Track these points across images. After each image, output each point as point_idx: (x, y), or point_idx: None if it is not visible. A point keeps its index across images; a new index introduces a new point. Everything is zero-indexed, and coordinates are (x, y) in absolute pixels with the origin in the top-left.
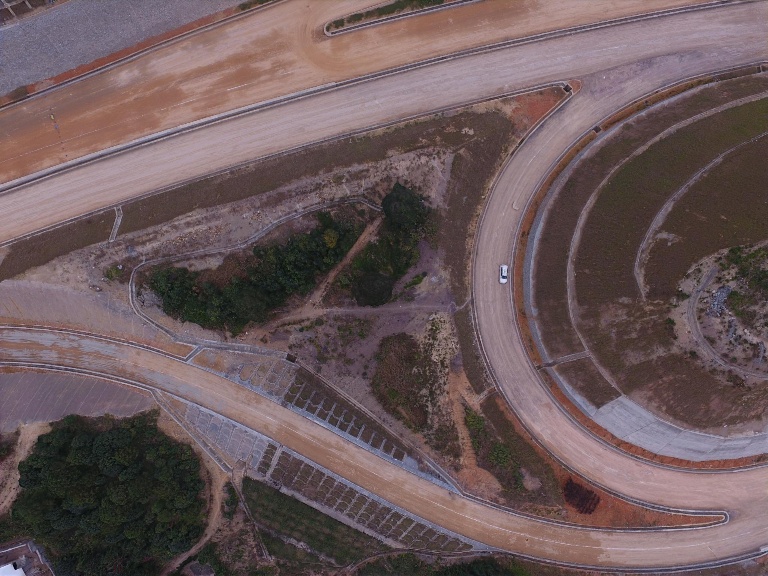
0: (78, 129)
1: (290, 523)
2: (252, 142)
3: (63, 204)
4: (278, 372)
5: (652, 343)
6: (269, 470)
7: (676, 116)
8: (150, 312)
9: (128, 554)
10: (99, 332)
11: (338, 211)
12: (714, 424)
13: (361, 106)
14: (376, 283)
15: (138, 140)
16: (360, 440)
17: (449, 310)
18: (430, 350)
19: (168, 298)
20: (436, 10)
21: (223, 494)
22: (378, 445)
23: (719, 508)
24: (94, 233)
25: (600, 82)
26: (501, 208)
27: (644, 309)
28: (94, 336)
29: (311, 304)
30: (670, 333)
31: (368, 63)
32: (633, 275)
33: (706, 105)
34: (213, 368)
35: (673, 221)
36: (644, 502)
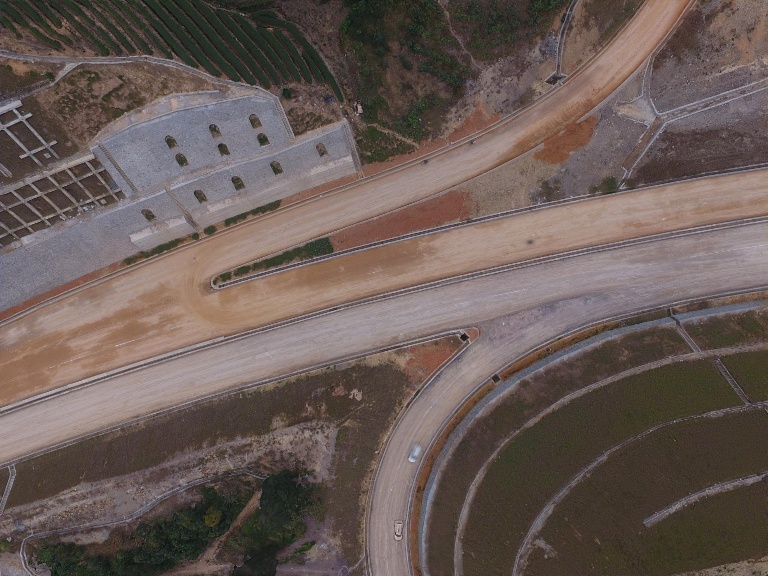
0: None
1: None
2: (142, 397)
3: None
4: None
5: None
6: None
7: (571, 382)
8: (44, 574)
9: None
10: None
11: (222, 485)
12: None
13: (252, 359)
14: None
15: (28, 400)
16: None
17: (340, 575)
18: None
19: (55, 575)
20: (326, 259)
21: None
22: None
23: None
24: None
25: (499, 329)
26: (396, 461)
27: None
28: None
29: (205, 561)
30: None
31: (258, 315)
32: None
33: (603, 371)
34: None
35: (551, 529)
36: None
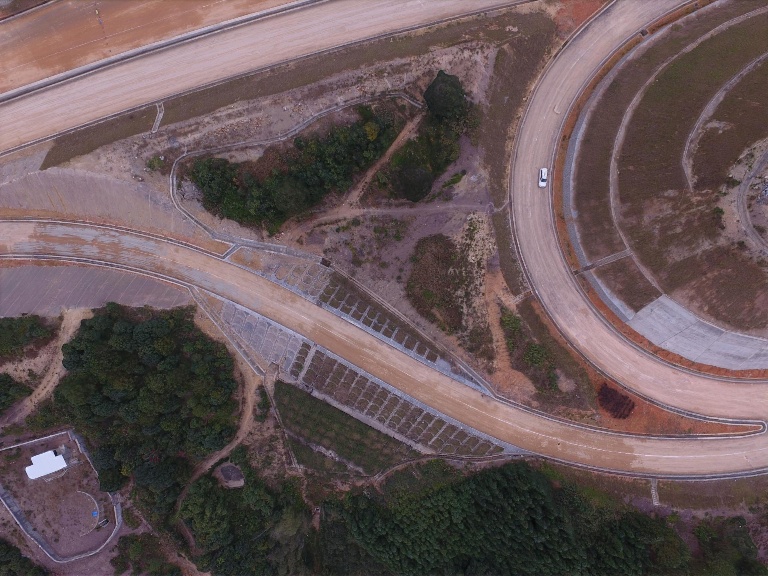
0: (122, 25)
1: (320, 429)
2: (293, 41)
3: (106, 100)
4: (313, 274)
5: (698, 236)
6: (301, 372)
7: (728, 14)
8: (190, 206)
9: (163, 448)
10: (139, 228)
11: (379, 105)
12: (757, 325)
13: (403, 6)
14: (418, 170)
15: (180, 36)
16: (394, 341)
17: (487, 210)
18: (467, 250)
19: (209, 188)
20: None
21: (255, 397)
22: (411, 347)
23: (757, 418)
24: (137, 126)
25: None
26: (542, 111)
27: (691, 200)
28: (134, 232)
29: (348, 204)
30: (718, 223)
31: None
32: (681, 165)
33: (760, 2)
34: (250, 266)
35: (725, 109)
36: (680, 409)
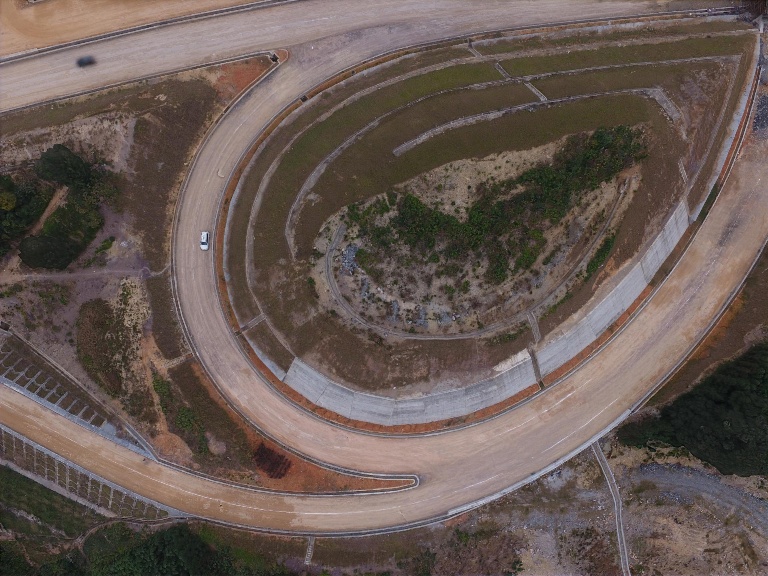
0: None
1: (13, 494)
2: None
3: None
4: None
5: (305, 303)
6: None
7: (364, 84)
8: None
9: None
10: None
11: (19, 174)
12: (381, 385)
13: (65, 73)
14: (30, 243)
15: None
16: (58, 406)
17: (140, 275)
18: (122, 315)
19: None
20: None
21: None
22: (77, 411)
23: (411, 472)
24: None
25: (308, 52)
26: (206, 175)
27: (294, 269)
28: None
29: (9, 270)
30: (312, 292)
31: (72, 30)
32: (284, 236)
33: (393, 74)
34: None
35: (321, 182)
36: (336, 466)
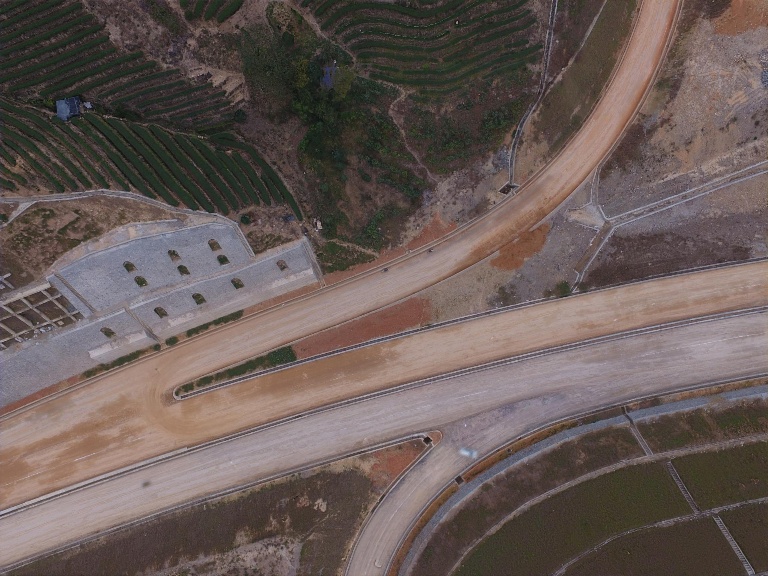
0: None
1: None
2: (103, 511)
3: None
4: None
5: None
6: None
7: (531, 487)
8: None
9: None
10: None
11: None
12: None
13: (215, 468)
14: None
15: None
16: None
17: None
18: None
19: None
20: (289, 367)
21: None
22: None
23: None
24: None
25: (461, 430)
26: (363, 567)
27: None
28: None
29: None
30: None
31: (221, 424)
32: None
33: (561, 475)
34: None
35: None
36: None
